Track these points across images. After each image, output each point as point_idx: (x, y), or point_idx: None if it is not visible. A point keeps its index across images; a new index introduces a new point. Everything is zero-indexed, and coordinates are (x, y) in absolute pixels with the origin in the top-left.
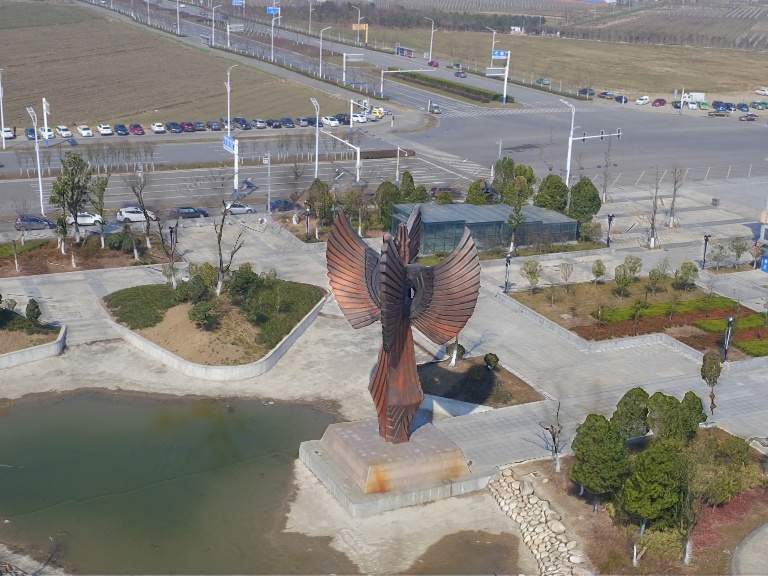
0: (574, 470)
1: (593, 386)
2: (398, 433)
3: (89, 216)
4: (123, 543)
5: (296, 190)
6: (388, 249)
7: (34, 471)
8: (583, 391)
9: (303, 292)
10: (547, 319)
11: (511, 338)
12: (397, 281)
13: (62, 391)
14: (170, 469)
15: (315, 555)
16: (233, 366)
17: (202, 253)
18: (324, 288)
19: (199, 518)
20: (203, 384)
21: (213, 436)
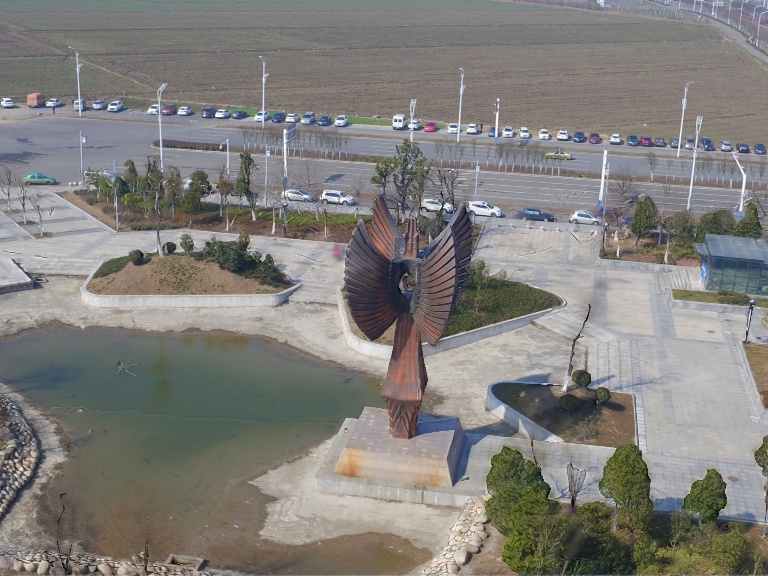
0: (489, 503)
1: (708, 452)
2: (398, 427)
3: (438, 203)
4: (130, 450)
5: (675, 211)
6: (356, 234)
7: (149, 384)
8: (688, 453)
9: (529, 299)
10: (752, 377)
11: (689, 386)
12: (368, 268)
13: (243, 333)
14: (239, 411)
15: (245, 507)
16: (381, 345)
17: (497, 250)
18: (563, 300)
19: (205, 451)
20: (352, 355)
21: (307, 397)
